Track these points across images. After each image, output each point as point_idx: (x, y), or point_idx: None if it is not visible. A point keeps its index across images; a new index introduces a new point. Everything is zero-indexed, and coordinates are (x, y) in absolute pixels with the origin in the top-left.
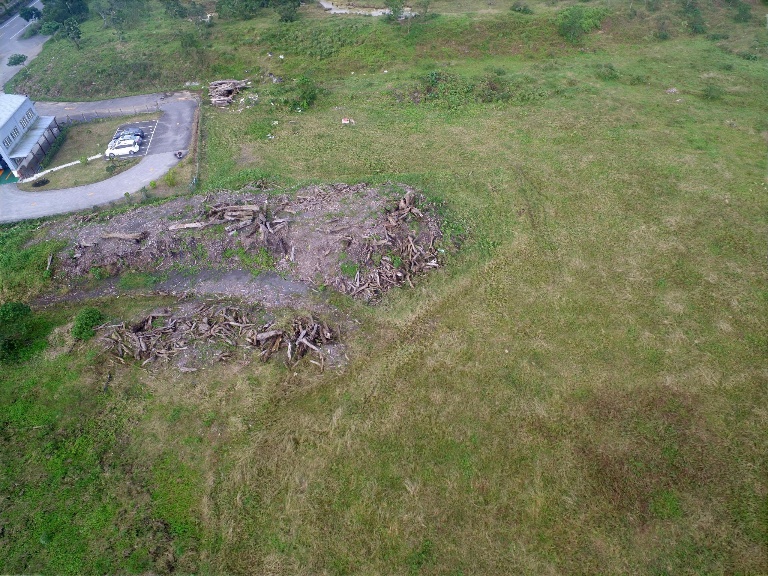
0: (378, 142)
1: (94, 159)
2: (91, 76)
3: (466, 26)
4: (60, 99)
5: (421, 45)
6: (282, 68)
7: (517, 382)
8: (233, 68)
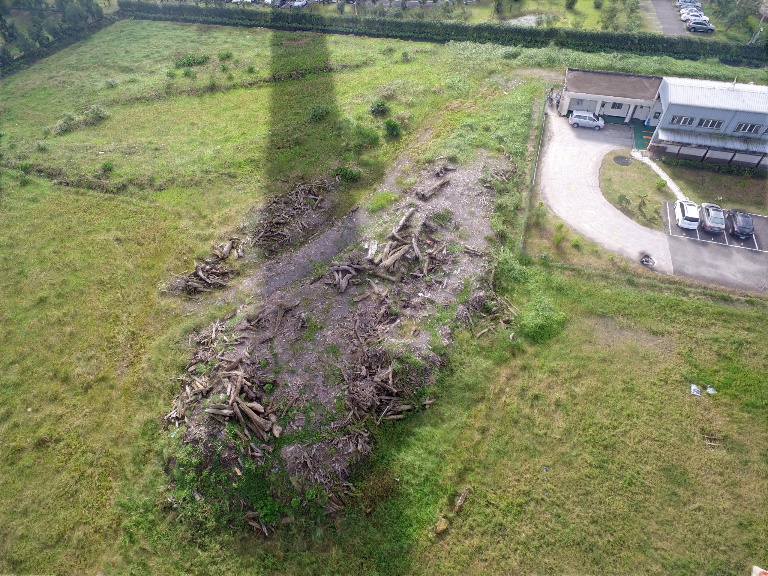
0: None
1: (673, 194)
2: None
3: None
4: None
5: None
6: None
7: (3, 390)
8: None
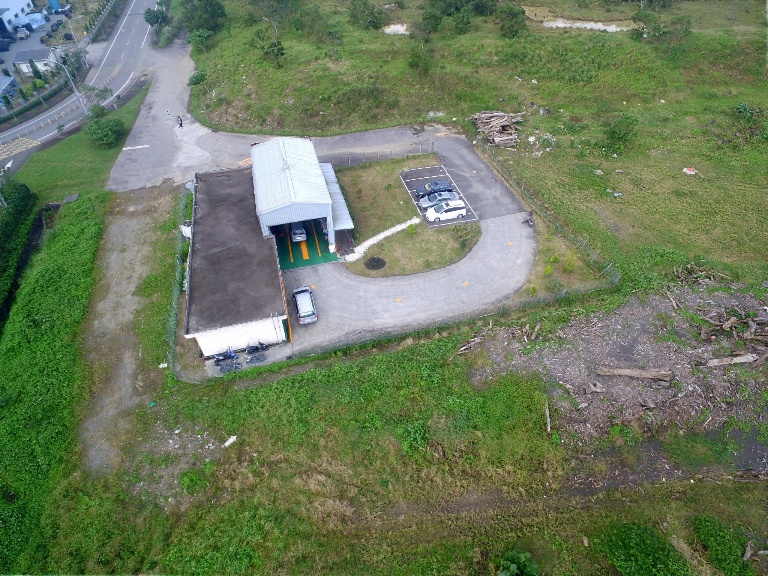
0: (767, 204)
1: (415, 225)
2: (316, 104)
3: (734, 47)
4: (285, 132)
5: (686, 68)
6: (542, 96)
7: None
8: (481, 95)
